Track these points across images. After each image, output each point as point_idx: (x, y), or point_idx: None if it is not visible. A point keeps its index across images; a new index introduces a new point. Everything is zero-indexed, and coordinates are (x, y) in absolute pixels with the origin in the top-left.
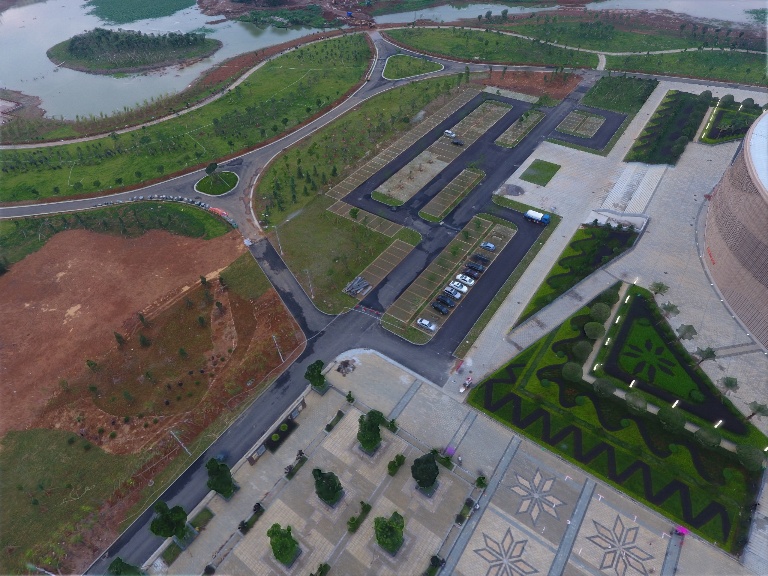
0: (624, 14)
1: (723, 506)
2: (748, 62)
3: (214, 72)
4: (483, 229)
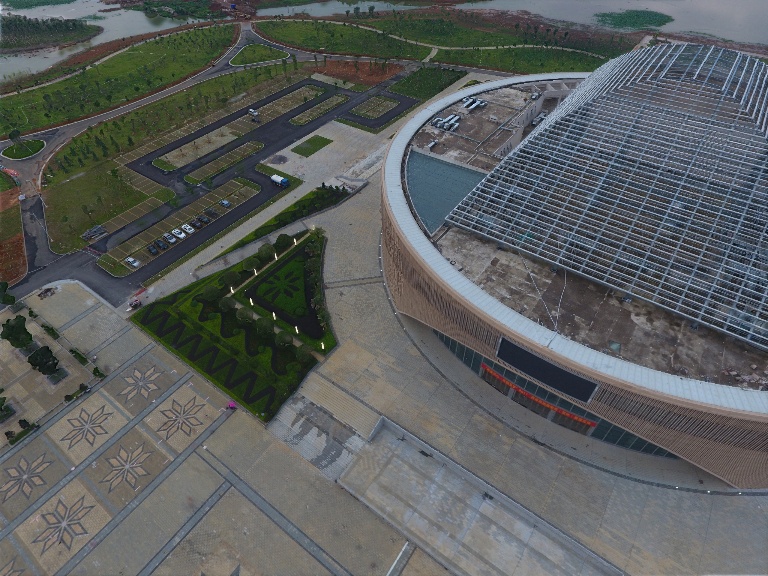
0: (485, 14)
1: (275, 389)
2: (555, 58)
3: (79, 55)
4: (231, 190)
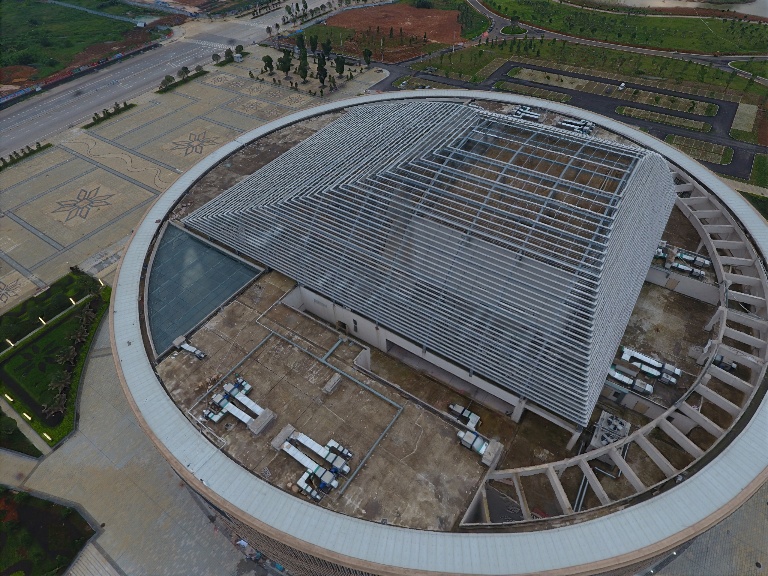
0: None
1: None
2: None
3: (679, 8)
4: None
